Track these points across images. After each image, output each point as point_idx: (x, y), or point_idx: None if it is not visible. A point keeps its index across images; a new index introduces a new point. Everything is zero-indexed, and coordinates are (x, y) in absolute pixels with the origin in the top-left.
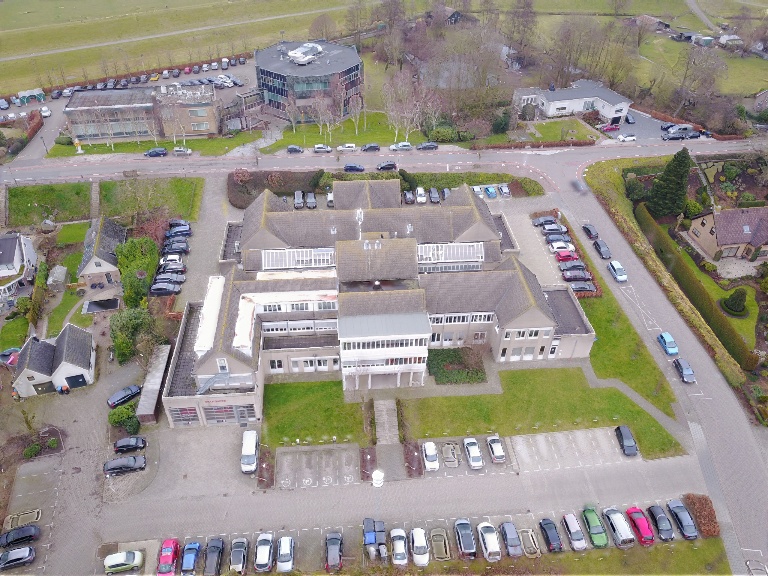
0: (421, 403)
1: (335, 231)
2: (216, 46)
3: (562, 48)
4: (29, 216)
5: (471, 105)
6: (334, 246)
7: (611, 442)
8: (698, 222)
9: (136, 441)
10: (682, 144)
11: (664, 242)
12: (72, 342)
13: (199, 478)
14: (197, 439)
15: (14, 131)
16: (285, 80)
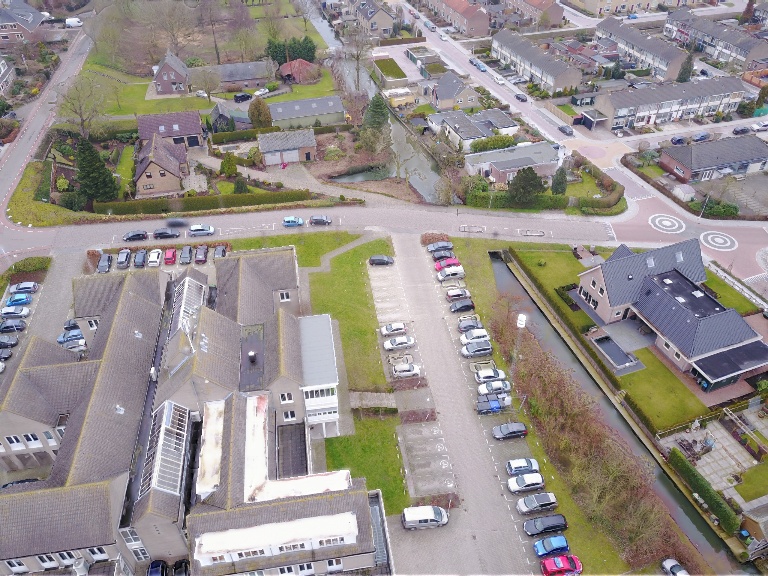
0: (352, 374)
1: (121, 409)
2: None
3: None
4: None
5: None
6: (166, 401)
7: (381, 269)
8: (143, 179)
9: None
10: (5, 161)
11: (161, 203)
12: None
13: (460, 570)
14: None
15: None
16: None
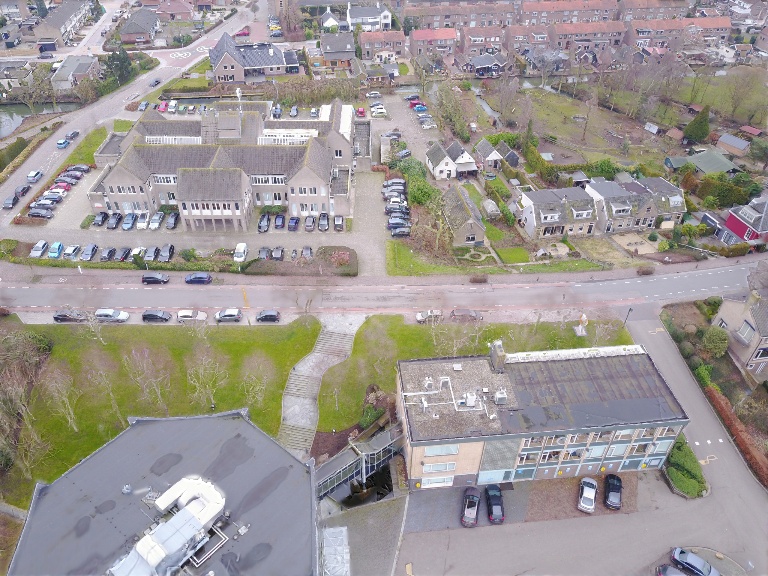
0: None
1: None
2: None
3: None
4: None
5: None
6: None
7: None
8: None
9: None
10: None
11: None
12: None
13: None
14: None
15: None
16: None
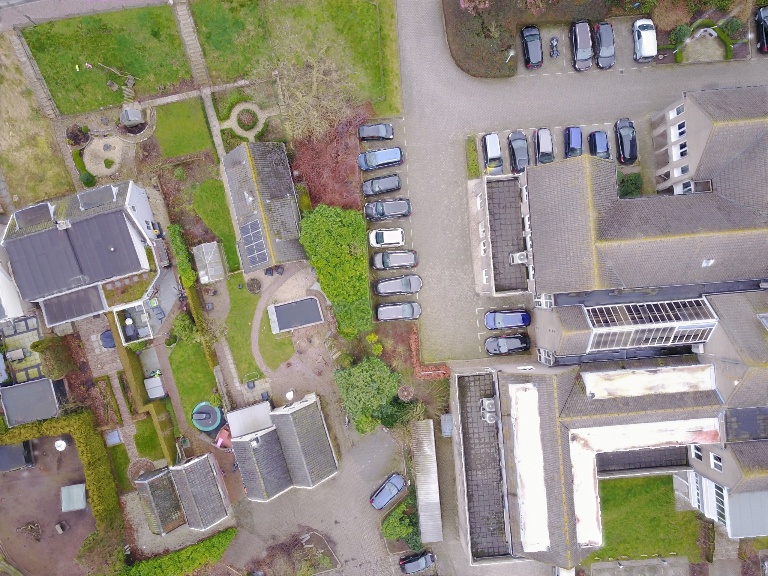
0: None
1: (710, 263)
2: None
3: None
4: (87, 90)
5: None
6: (717, 321)
7: None
8: None
9: (425, 562)
10: None
11: None
12: (305, 442)
13: None
14: None
15: None
16: None
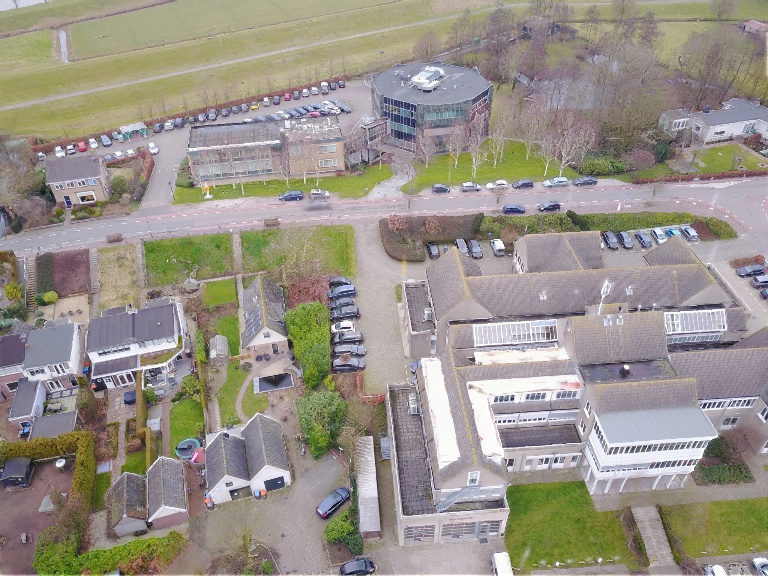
0: (687, 511)
1: (544, 297)
2: (315, 69)
3: (708, 64)
4: (168, 273)
5: (607, 129)
6: None
7: None
8: None
9: (365, 564)
10: None
11: None
12: (267, 437)
13: None
14: (434, 561)
15: (124, 171)
16: (414, 109)
